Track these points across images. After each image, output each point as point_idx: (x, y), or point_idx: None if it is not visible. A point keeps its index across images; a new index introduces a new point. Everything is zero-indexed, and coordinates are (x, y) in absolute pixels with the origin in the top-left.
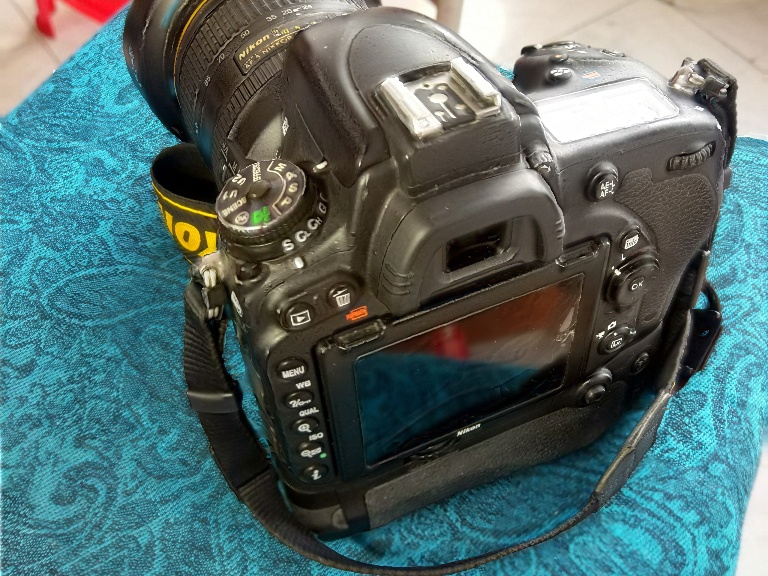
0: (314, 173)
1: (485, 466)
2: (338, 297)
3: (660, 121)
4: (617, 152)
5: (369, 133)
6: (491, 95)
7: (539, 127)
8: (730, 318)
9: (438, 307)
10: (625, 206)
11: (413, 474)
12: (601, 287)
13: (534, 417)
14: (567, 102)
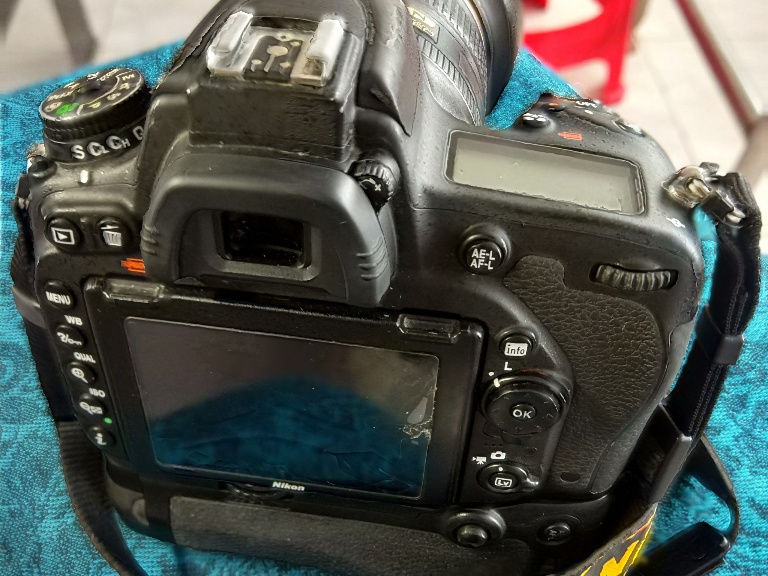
0: (149, 93)
1: (320, 547)
2: (107, 231)
3: (601, 211)
4: (516, 221)
5: (185, 59)
6: (314, 59)
7: (392, 135)
8: (760, 562)
9: (231, 304)
10: (521, 299)
11: (230, 506)
12: (471, 391)
13: (394, 523)
14: (511, 149)
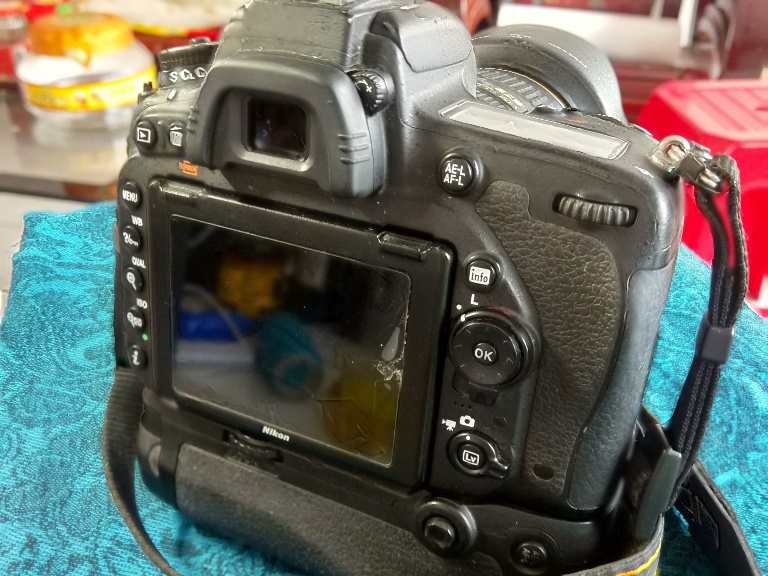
0: None
1: (298, 528)
2: (173, 132)
3: None
4: (490, 147)
5: None
6: None
7: (392, 56)
8: None
9: (250, 206)
10: (491, 228)
11: (228, 464)
12: (440, 325)
13: (371, 512)
14: (515, 118)
